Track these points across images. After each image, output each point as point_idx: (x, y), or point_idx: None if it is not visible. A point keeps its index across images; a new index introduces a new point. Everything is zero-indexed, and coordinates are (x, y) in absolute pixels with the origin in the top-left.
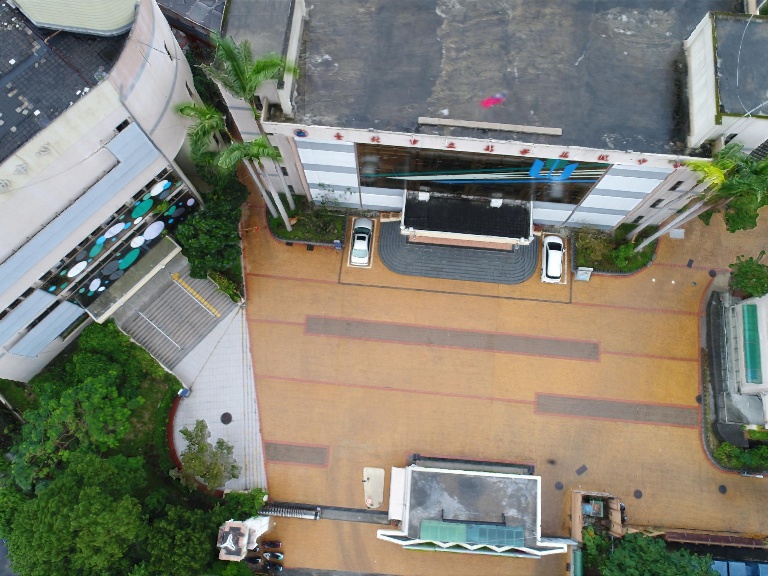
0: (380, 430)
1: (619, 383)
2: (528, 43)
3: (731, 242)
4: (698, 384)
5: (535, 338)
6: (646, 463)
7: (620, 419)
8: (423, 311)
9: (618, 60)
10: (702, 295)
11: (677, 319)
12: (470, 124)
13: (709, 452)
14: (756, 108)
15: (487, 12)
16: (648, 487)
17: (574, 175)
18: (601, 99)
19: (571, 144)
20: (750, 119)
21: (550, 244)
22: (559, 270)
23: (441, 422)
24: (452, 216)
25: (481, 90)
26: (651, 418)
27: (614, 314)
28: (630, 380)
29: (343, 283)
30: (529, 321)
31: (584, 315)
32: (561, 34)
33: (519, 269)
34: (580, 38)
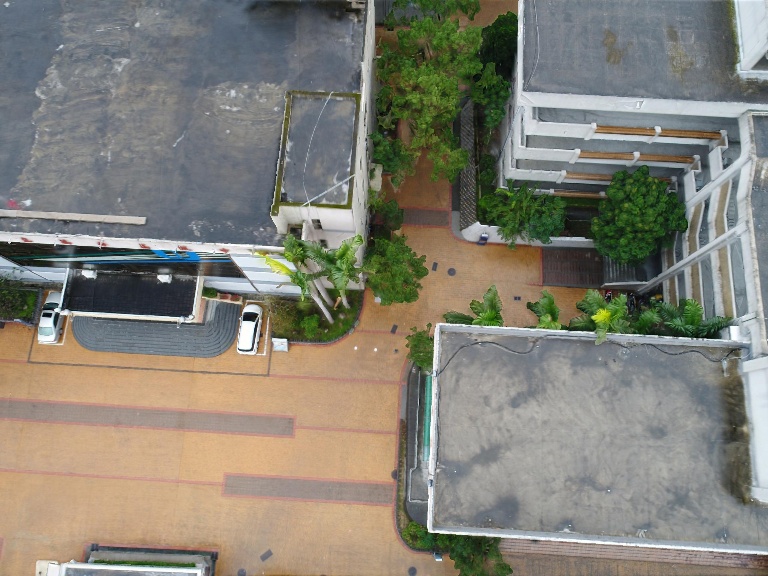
0: (58, 519)
1: (312, 460)
2: (127, 124)
3: (438, 305)
4: (395, 458)
5: (228, 414)
6: (334, 545)
7: (311, 499)
8: (113, 389)
9: (219, 139)
10: (404, 363)
11: (377, 389)
12: (49, 215)
13: (398, 532)
14: (319, 196)
15: (89, 91)
16: (334, 572)
17: (203, 256)
18: (194, 183)
19: (155, 233)
20: (310, 208)
21: (246, 314)
22: (250, 343)
23: (123, 508)
24: (120, 294)
25: (69, 177)
26: (343, 497)
27: (312, 386)
28: (324, 456)
29: (33, 362)
30: (223, 396)
31: (281, 388)
32: (163, 113)
33: (213, 342)
34: (183, 117)
